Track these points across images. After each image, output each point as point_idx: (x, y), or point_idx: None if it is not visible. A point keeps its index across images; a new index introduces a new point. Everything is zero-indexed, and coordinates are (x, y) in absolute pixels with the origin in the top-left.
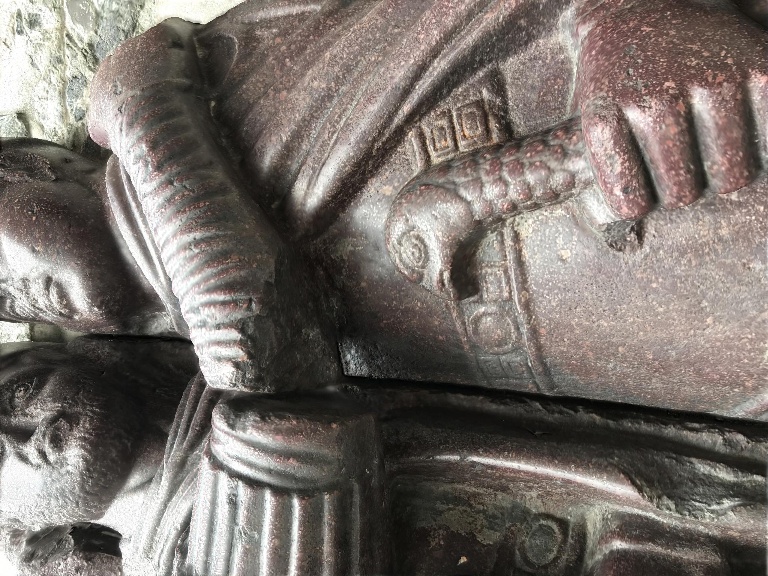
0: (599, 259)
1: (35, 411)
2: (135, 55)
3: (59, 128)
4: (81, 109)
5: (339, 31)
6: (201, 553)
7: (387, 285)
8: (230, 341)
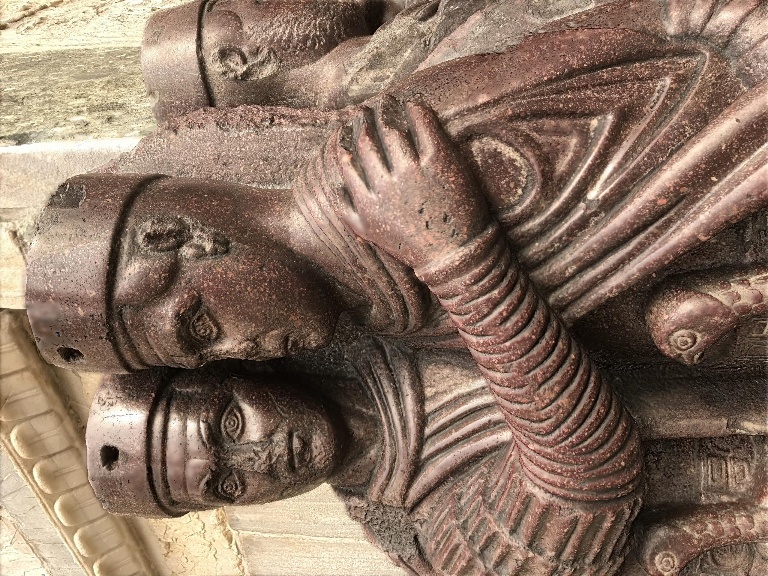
0: None
1: None
2: None
3: None
4: None
5: None
6: None
7: None
8: None
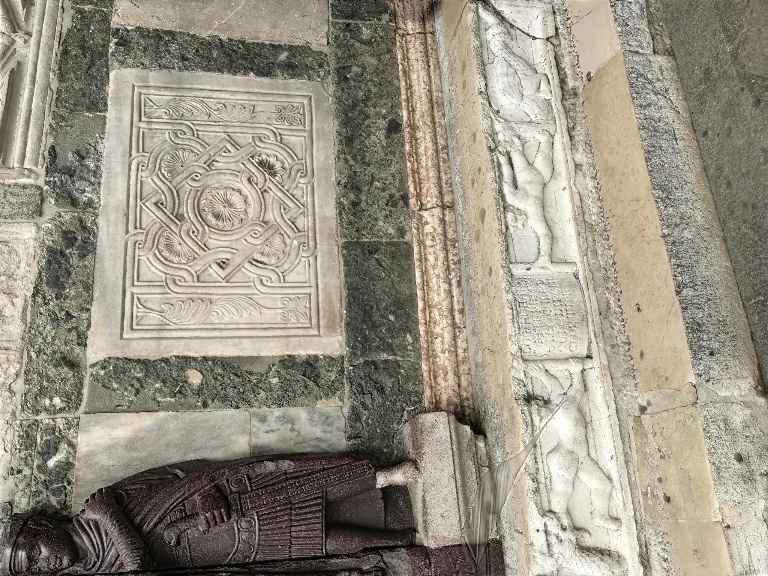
0: (202, 536)
1: None
2: (104, 500)
3: (26, 507)
4: (38, 501)
5: (152, 494)
6: None
7: (160, 546)
8: (137, 559)
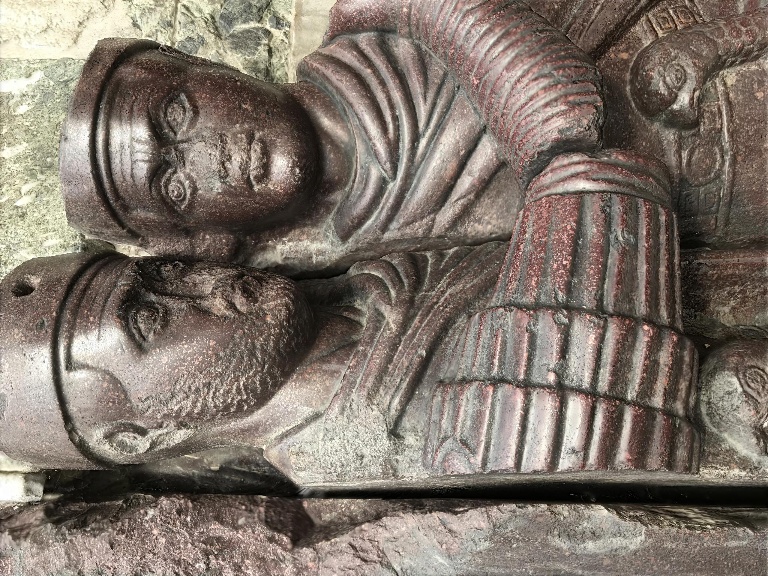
0: None
1: (200, 277)
2: None
3: None
4: None
5: None
6: (568, 272)
7: (621, 127)
8: (588, 91)
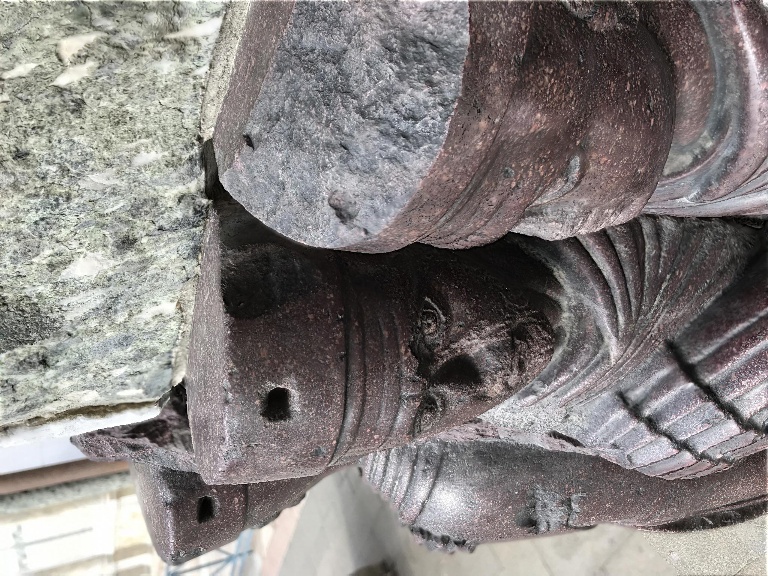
0: None
1: None
2: None
3: None
4: None
5: None
6: None
7: None
8: None
